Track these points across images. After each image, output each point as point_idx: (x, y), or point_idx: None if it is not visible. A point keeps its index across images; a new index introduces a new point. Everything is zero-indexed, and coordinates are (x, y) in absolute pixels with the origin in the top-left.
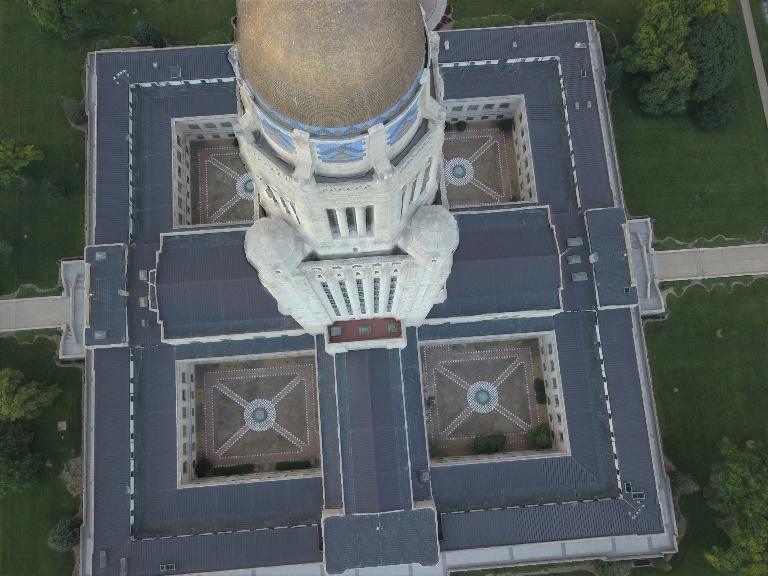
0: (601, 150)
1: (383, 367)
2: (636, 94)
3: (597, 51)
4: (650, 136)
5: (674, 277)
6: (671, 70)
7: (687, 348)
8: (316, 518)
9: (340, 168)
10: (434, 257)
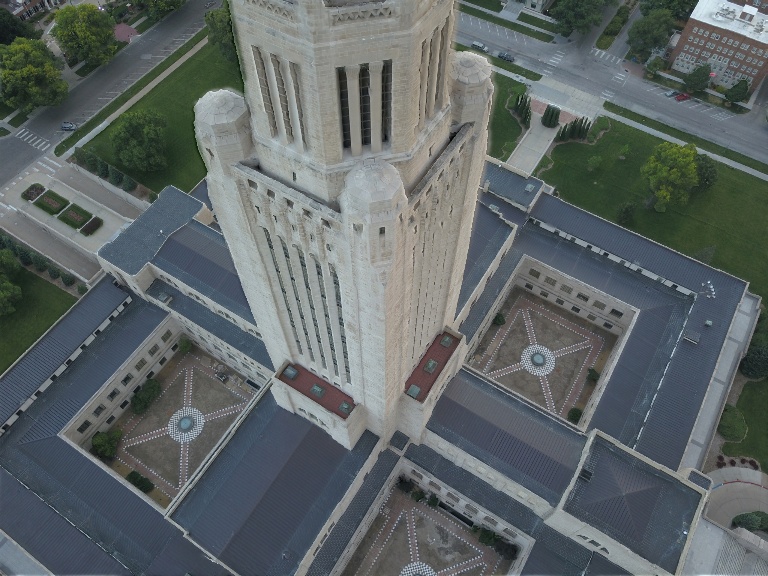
0: None
1: None
2: None
3: None
4: None
5: None
6: None
7: None
8: None
9: None
10: None
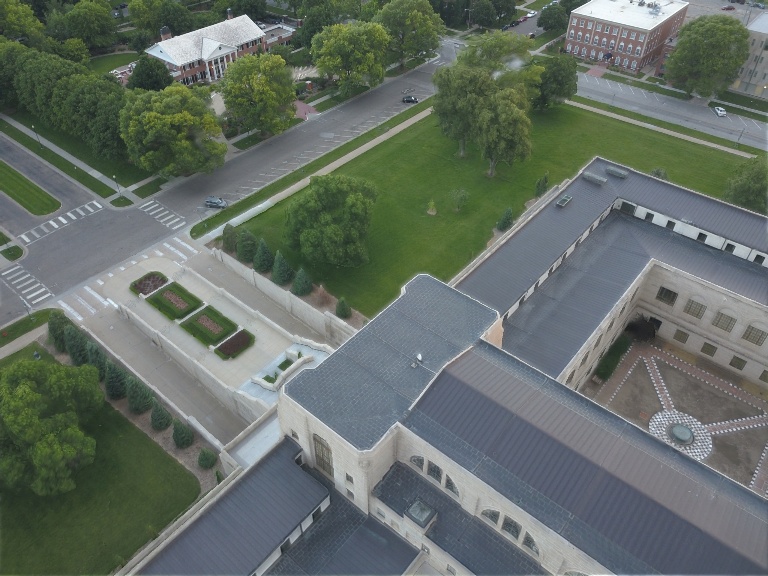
0: None
1: None
2: None
3: None
4: None
5: None
6: None
7: None
8: None
9: None
10: None
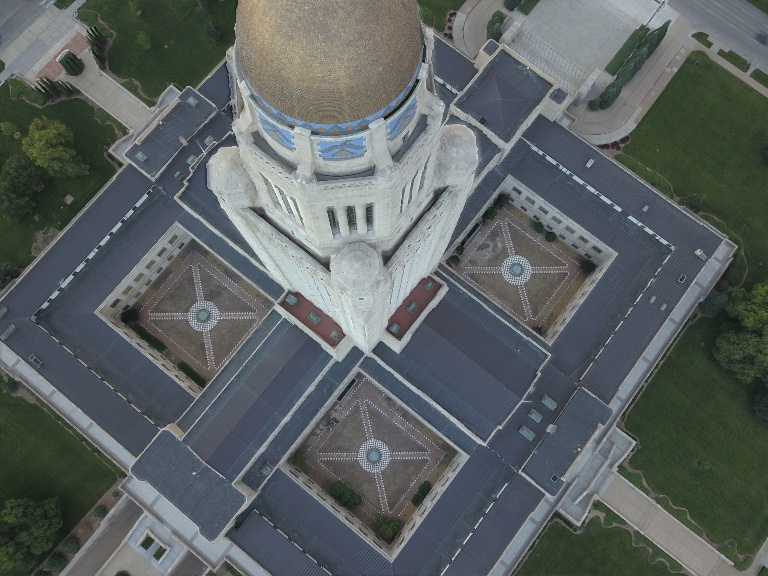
0: (640, 351)
1: (309, 360)
2: (719, 335)
3: (717, 272)
4: (701, 378)
5: (615, 507)
6: (761, 339)
7: (572, 573)
8: (166, 425)
9: (276, 145)
10: (340, 289)
